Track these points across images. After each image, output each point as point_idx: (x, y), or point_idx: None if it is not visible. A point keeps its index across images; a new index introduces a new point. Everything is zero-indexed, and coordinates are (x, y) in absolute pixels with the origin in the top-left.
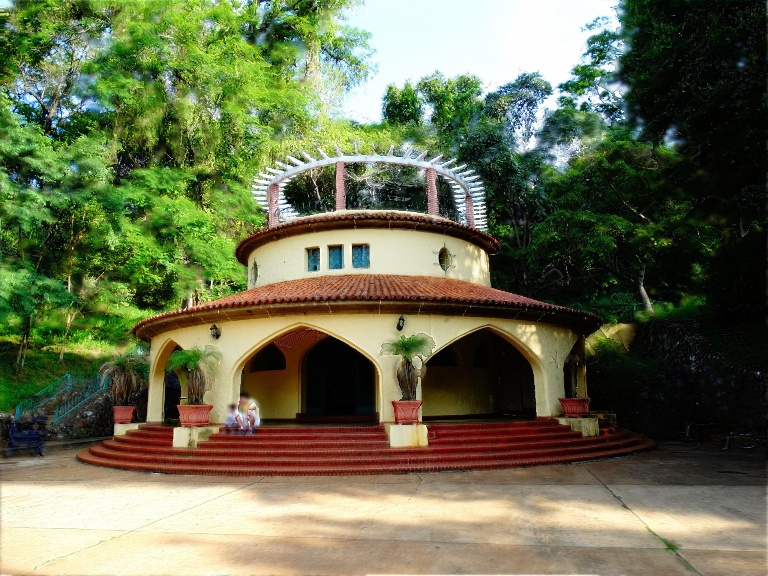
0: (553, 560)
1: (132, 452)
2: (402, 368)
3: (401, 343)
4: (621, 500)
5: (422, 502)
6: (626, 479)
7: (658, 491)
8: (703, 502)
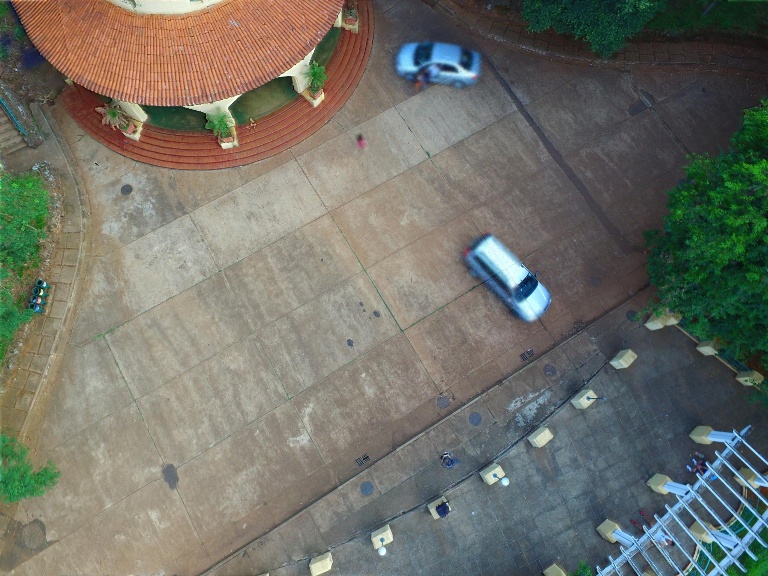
0: (416, 176)
1: (200, 157)
2: (313, 82)
3: (309, 72)
4: (406, 123)
5: (365, 152)
6: (396, 94)
7: (410, 108)
8: (423, 116)
